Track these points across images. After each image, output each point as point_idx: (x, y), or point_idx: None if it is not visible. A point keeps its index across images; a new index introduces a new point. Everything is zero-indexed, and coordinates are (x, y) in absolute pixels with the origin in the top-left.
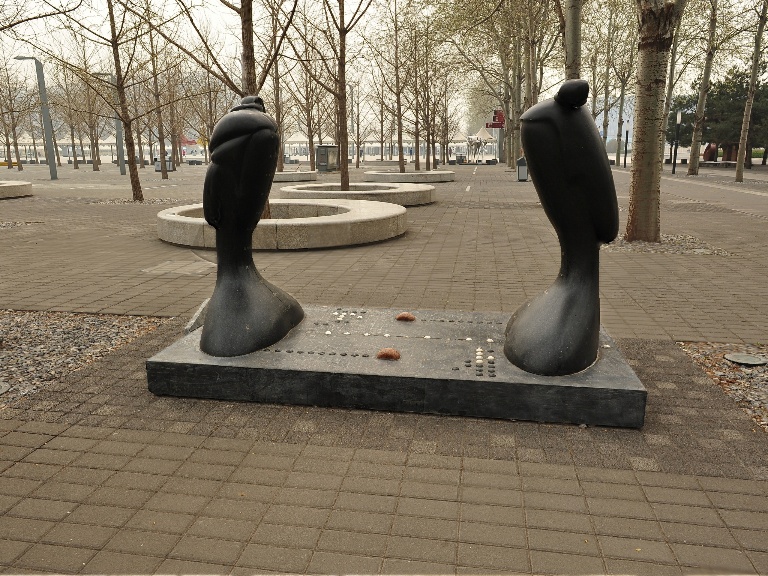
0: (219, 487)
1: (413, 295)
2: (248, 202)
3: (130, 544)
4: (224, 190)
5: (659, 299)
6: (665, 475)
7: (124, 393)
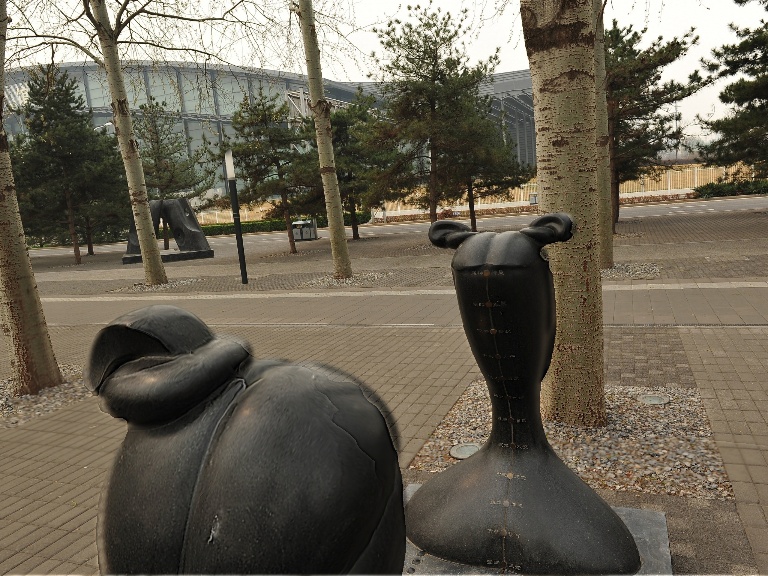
0: None
1: None
2: None
3: None
4: None
5: None
6: (766, 567)
7: None
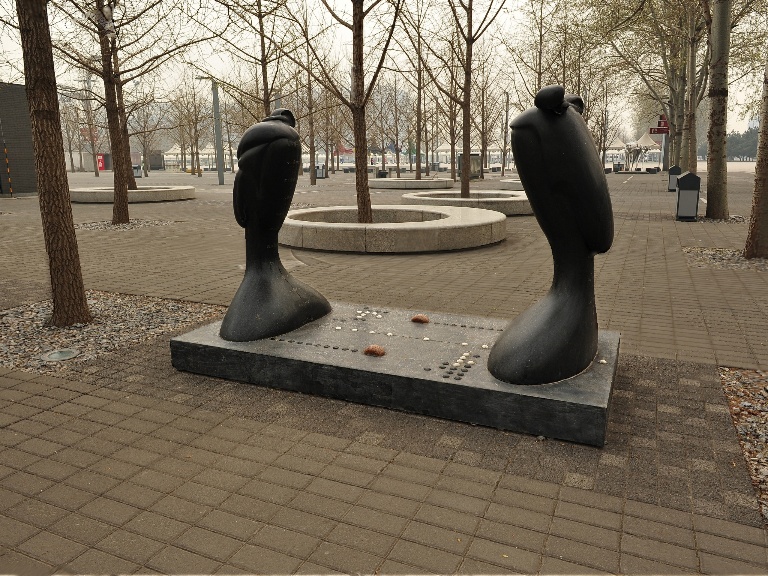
0: (176, 448)
1: (465, 301)
2: (268, 204)
3: (82, 481)
4: (248, 193)
5: (736, 321)
6: (591, 494)
7: (155, 366)
